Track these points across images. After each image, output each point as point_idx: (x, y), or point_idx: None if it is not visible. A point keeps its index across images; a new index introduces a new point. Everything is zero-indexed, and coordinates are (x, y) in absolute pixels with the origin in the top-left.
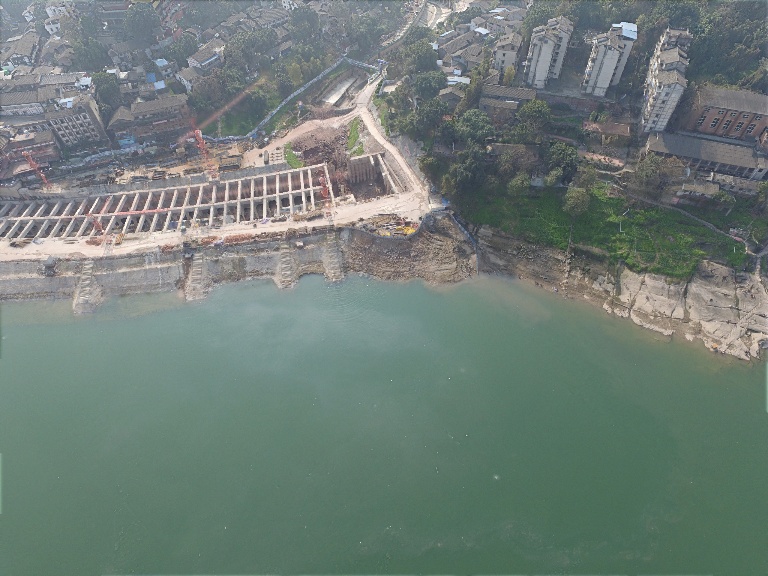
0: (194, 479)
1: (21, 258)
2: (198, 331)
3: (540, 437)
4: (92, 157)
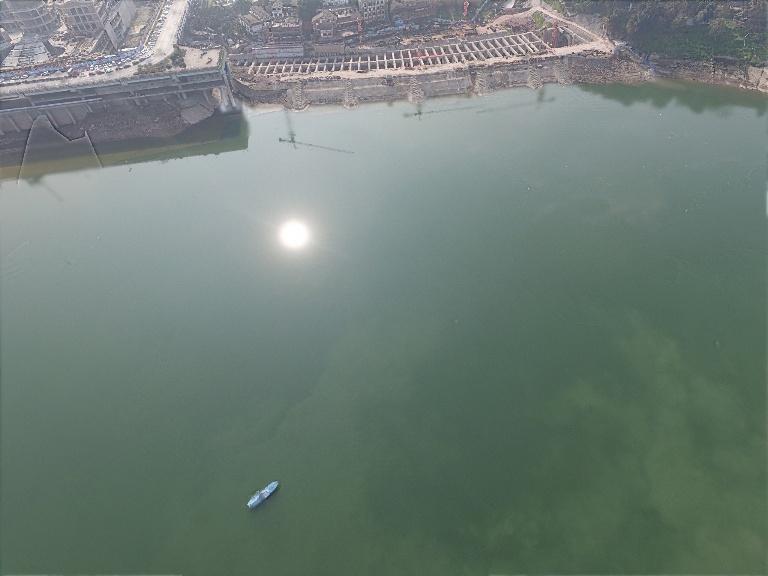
0: (537, 153)
1: (370, 77)
2: (497, 105)
3: (724, 131)
4: (380, 31)
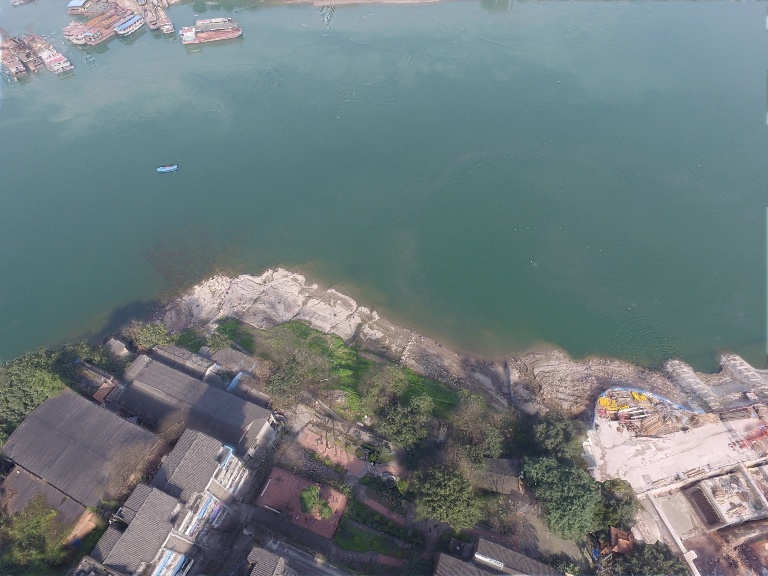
0: (699, 213)
1: None
2: None
3: (464, 226)
4: None
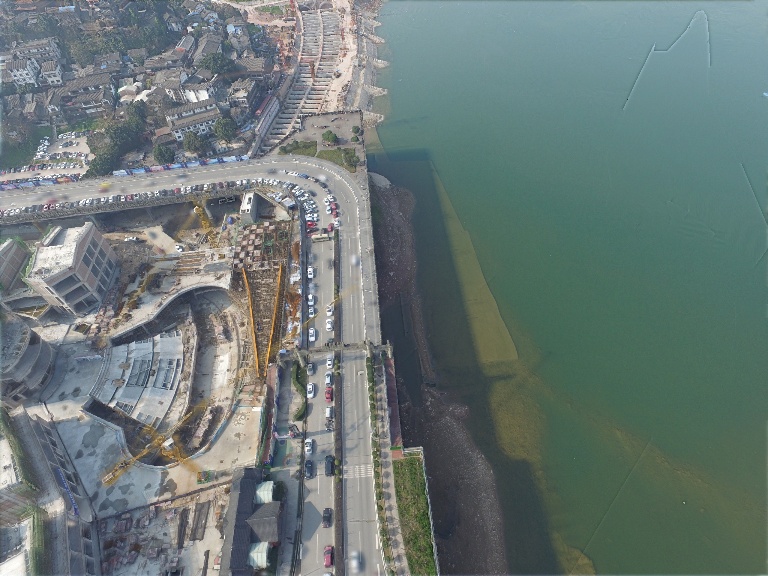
0: (470, 29)
1: None
2: (405, 35)
3: None
4: None
